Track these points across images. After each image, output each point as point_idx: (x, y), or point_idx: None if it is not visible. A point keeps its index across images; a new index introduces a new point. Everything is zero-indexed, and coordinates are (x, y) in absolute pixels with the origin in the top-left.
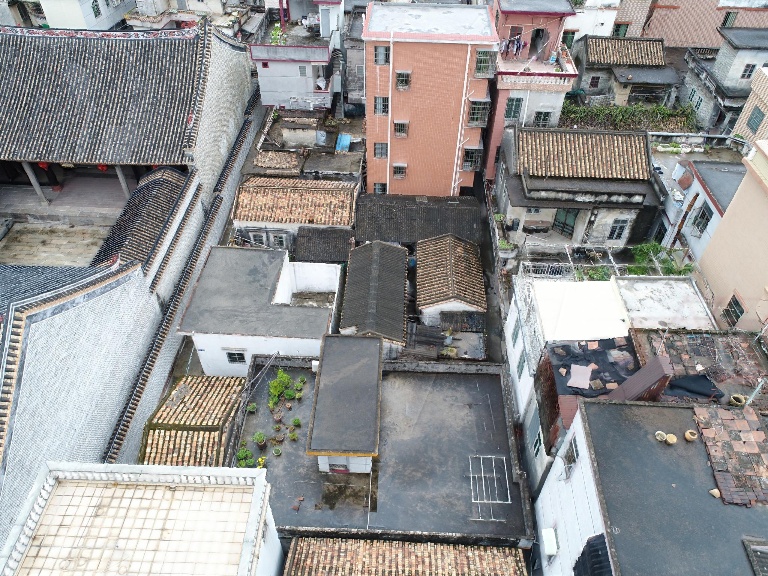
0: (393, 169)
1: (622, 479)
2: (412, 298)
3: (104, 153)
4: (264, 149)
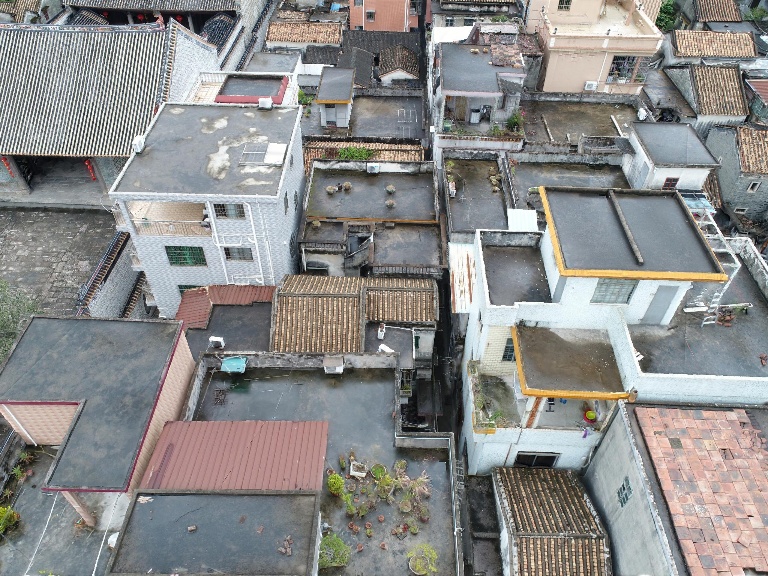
0: (366, 14)
1: (452, 60)
2: (377, 81)
3: (183, 4)
4: (283, 10)
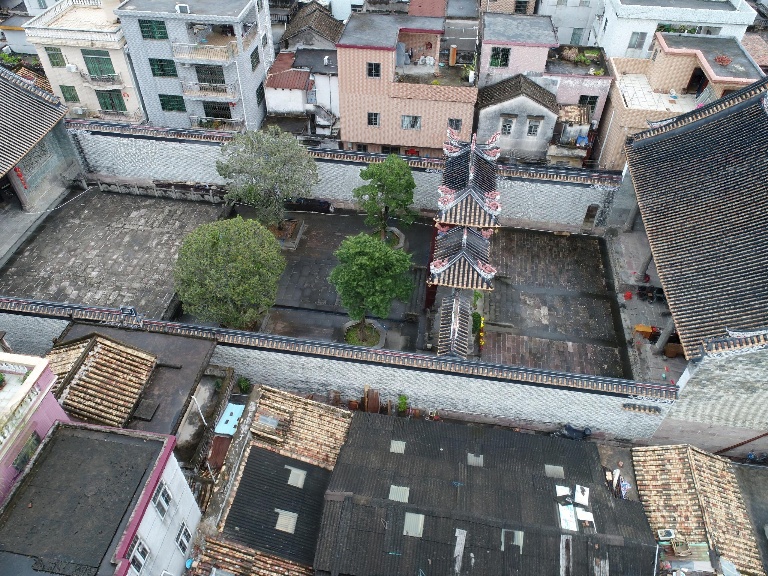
0: None
1: None
2: None
3: None
4: None
